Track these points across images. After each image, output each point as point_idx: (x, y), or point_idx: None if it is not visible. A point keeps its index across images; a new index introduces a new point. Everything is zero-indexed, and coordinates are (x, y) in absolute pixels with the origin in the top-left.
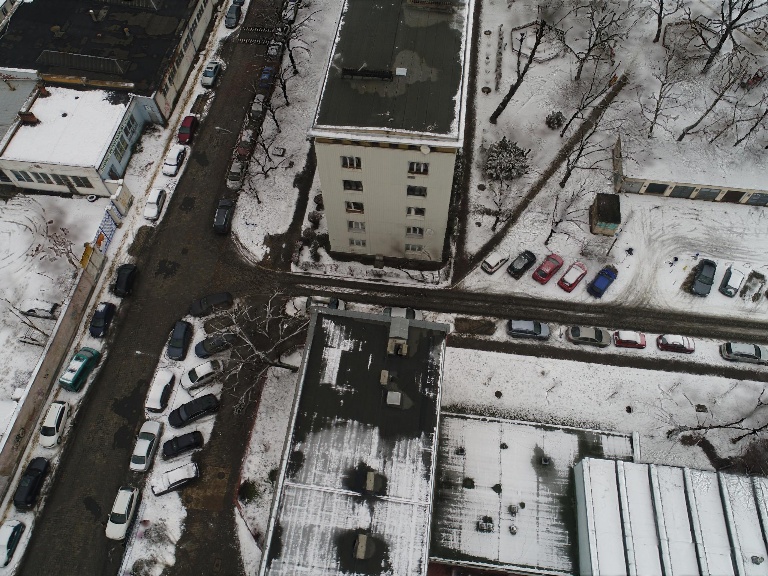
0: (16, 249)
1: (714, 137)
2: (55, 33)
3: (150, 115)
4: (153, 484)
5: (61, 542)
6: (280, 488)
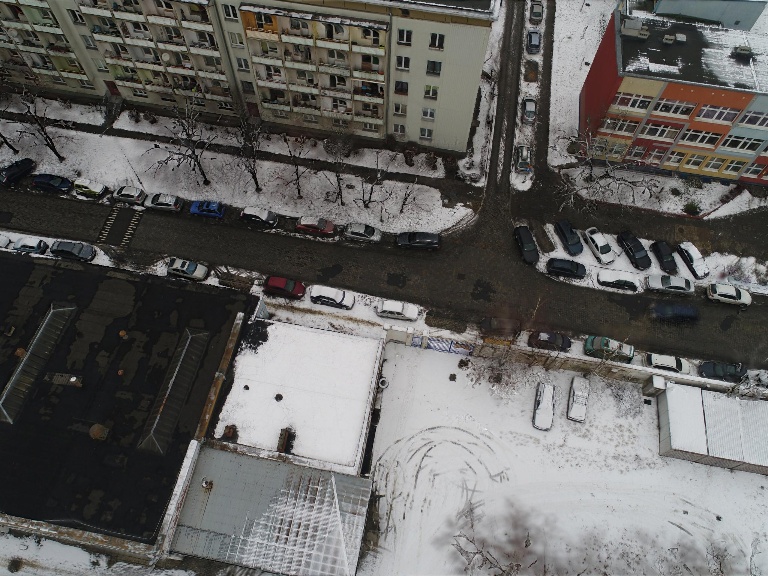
0: (460, 460)
1: None
2: (100, 437)
3: None
4: (703, 273)
5: (761, 343)
6: (765, 92)
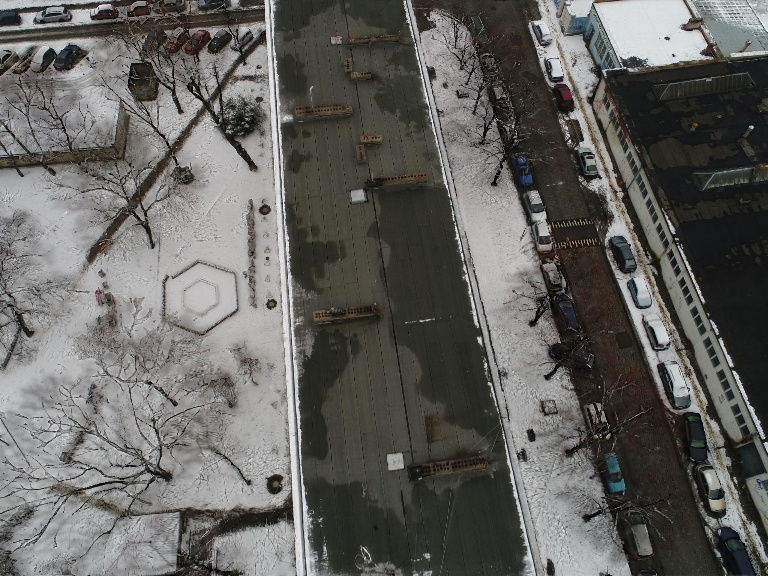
0: None
1: (5, 194)
2: None
3: None
4: None
5: None
6: None
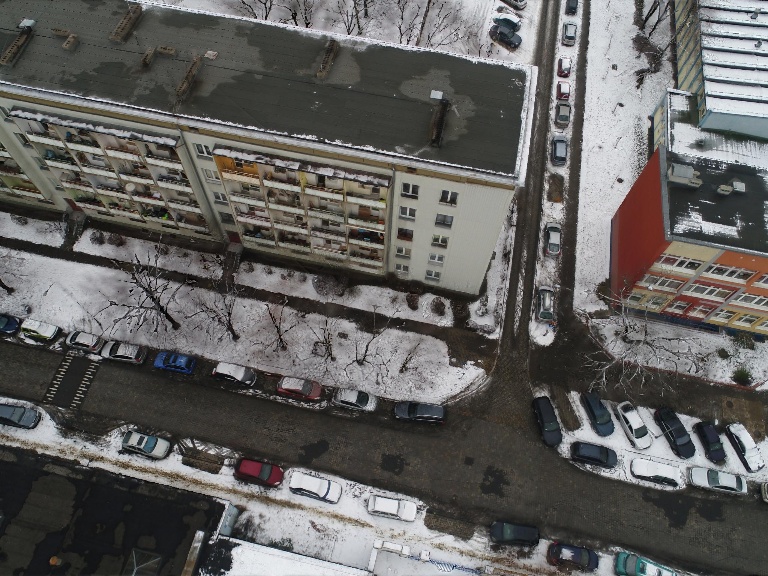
0: None
1: None
2: None
3: (229, 526)
4: (756, 467)
5: None
6: None
